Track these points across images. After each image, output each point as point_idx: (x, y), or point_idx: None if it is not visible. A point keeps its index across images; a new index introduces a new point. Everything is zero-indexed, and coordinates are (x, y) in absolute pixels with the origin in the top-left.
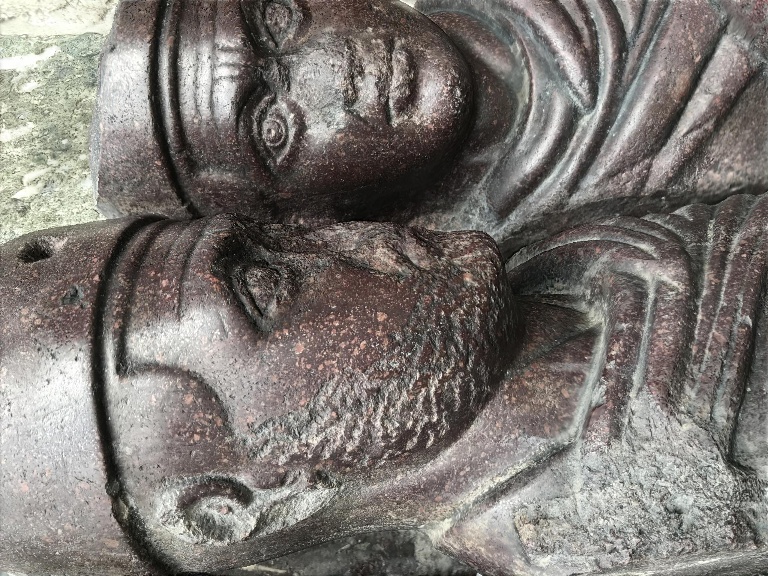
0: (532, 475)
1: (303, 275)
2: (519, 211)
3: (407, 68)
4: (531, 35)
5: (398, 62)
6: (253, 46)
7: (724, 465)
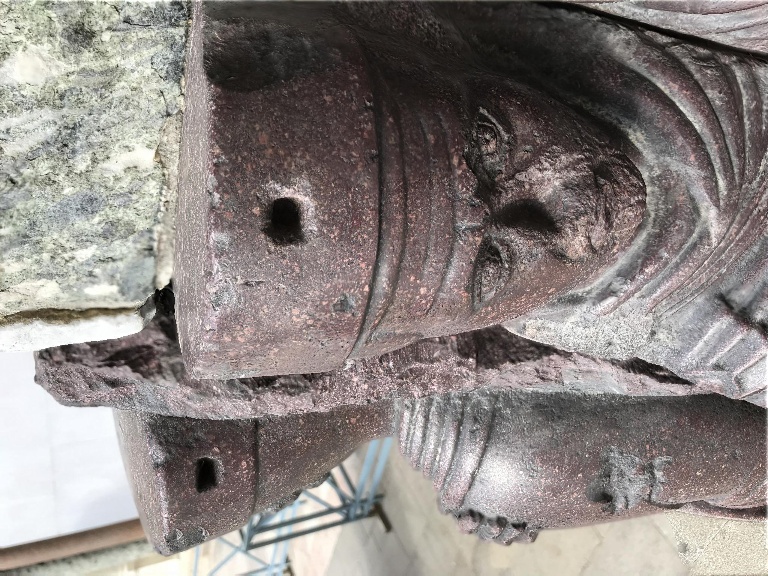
0: (552, 309)
1: (517, 260)
2: (662, 14)
3: None
4: None
5: None
6: None
7: (647, 336)
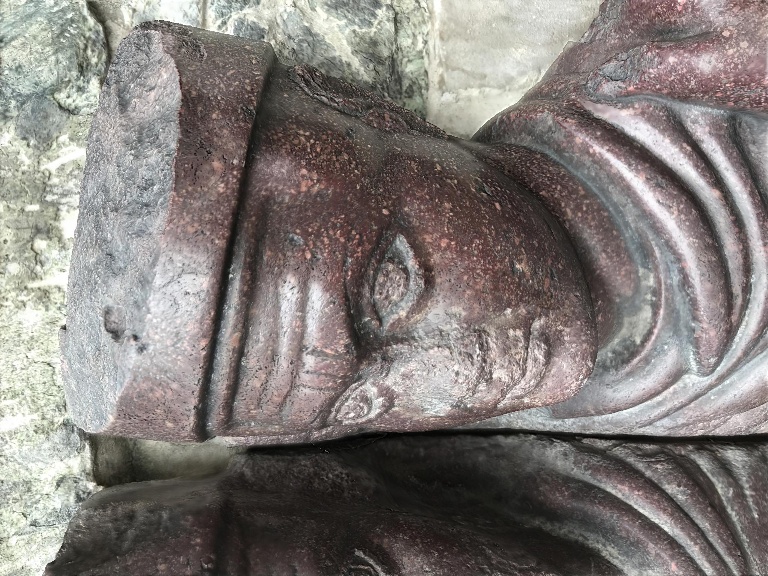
0: None
1: None
2: (578, 421)
3: (542, 368)
4: (675, 280)
5: (534, 362)
6: (356, 347)
7: None
